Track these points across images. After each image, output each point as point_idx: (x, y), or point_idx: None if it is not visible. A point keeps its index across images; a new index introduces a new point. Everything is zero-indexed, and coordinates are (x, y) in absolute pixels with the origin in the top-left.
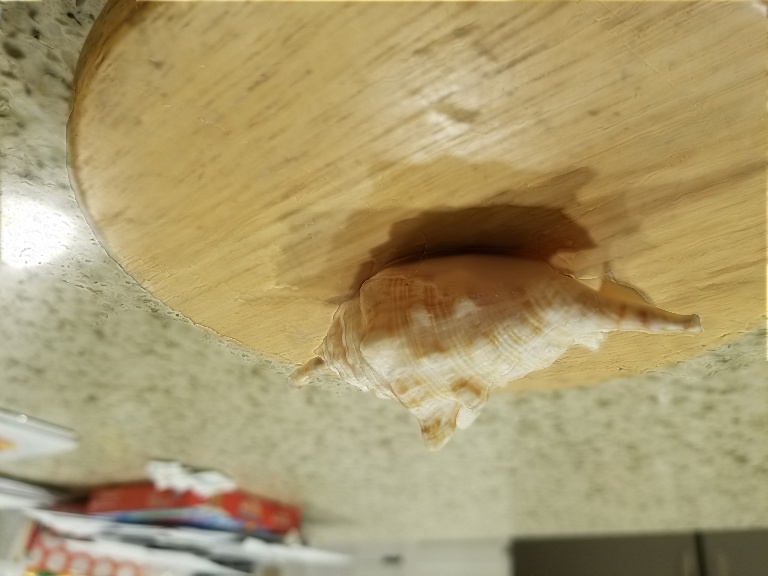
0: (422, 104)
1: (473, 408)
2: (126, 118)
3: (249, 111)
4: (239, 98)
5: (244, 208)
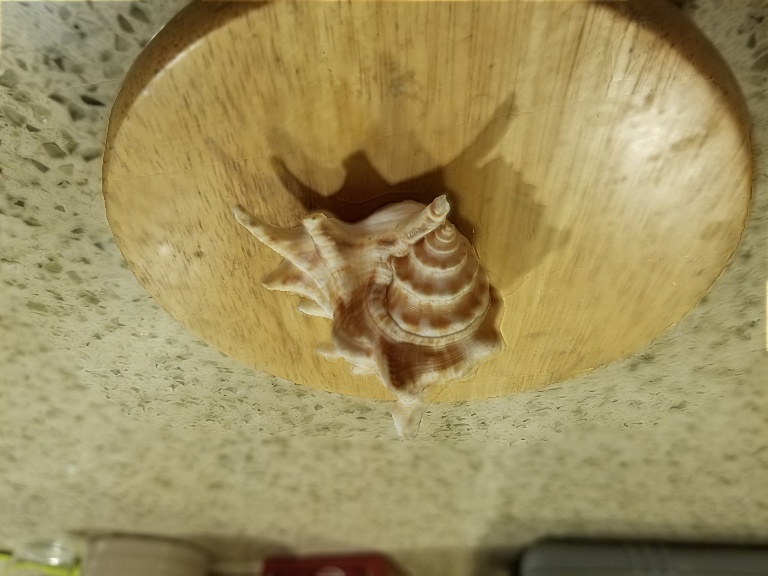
0: (562, 327)
1: (421, 400)
2: (709, 233)
3: (638, 280)
4: (647, 279)
5: (596, 216)
